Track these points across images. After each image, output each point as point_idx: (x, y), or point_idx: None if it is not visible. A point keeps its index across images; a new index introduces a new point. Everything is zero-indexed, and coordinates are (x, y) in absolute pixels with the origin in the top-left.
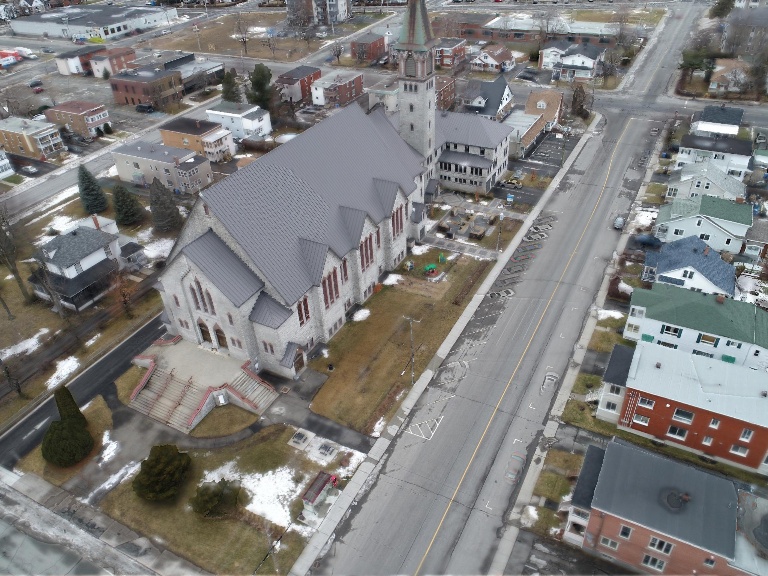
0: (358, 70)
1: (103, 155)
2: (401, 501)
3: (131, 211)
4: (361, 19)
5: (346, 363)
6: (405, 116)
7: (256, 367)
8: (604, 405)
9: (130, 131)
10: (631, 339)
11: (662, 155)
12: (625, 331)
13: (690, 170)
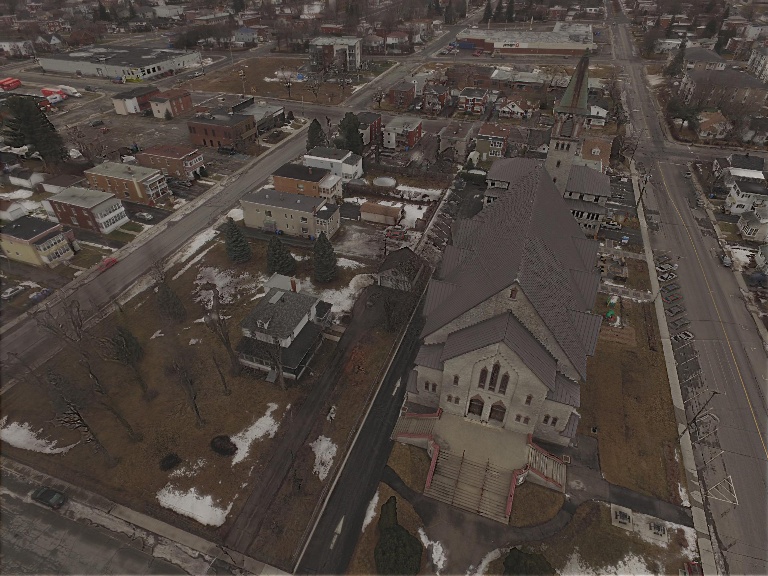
0: (400, 114)
1: (210, 199)
2: None
3: (286, 262)
4: (375, 67)
5: (603, 423)
6: (550, 171)
7: None
8: None
9: (223, 174)
10: None
11: (709, 196)
12: None
13: (767, 214)
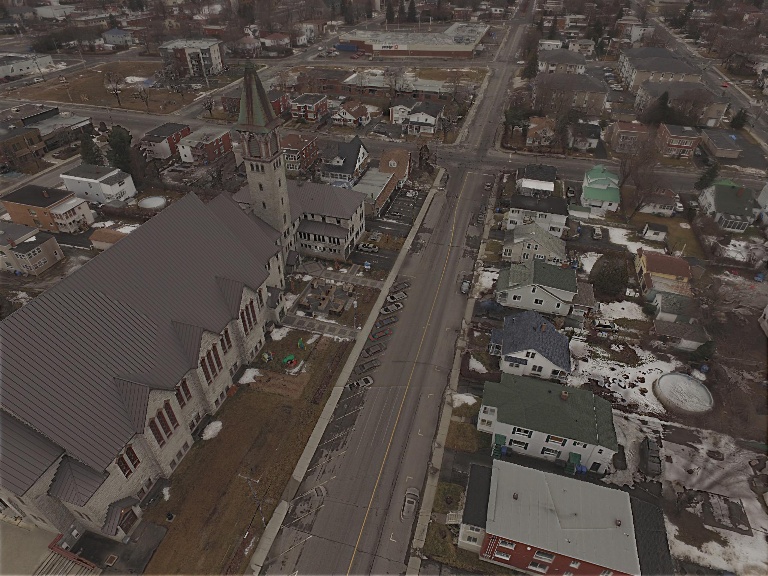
0: (230, 123)
1: None
2: None
3: None
4: (235, 71)
5: (189, 506)
6: (256, 194)
7: (74, 534)
8: (465, 538)
9: None
10: (485, 431)
11: (496, 210)
12: (479, 425)
13: (521, 232)
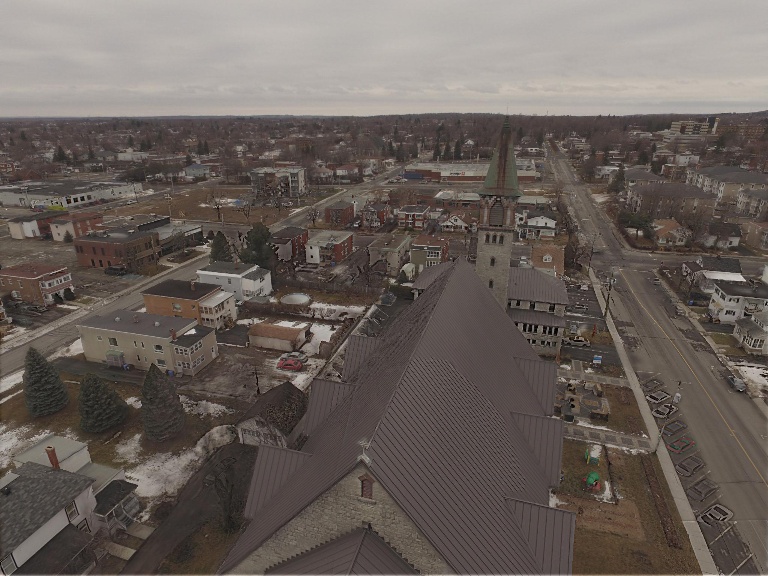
0: None
1: (61, 327)
2: None
3: (107, 412)
4: (319, 193)
5: None
6: (483, 271)
7: None
8: None
9: (98, 296)
10: None
11: (688, 303)
12: None
13: None
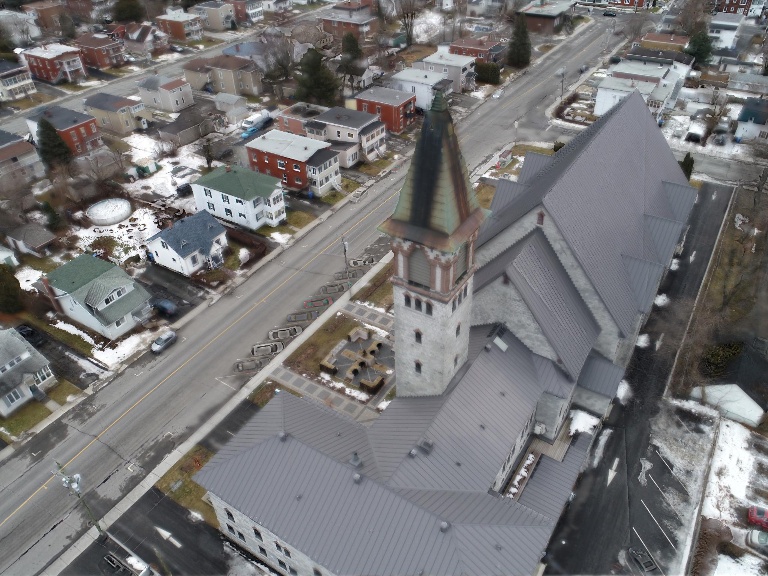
0: None
1: None
2: None
3: None
4: None
5: None
6: None
7: None
8: None
9: None
10: None
11: None
12: None
13: (3, 354)
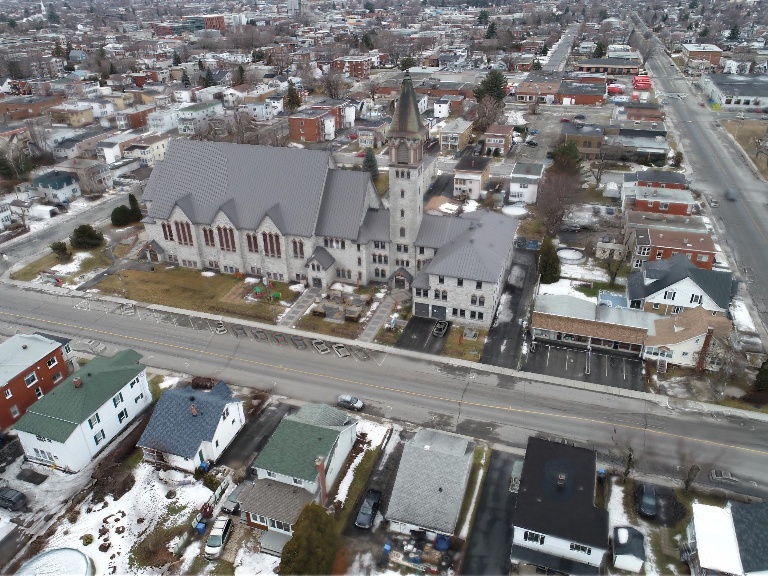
0: None
1: None
2: (34, 302)
3: None
4: None
5: (156, 274)
6: None
7: None
8: None
9: (506, 161)
10: None
11: None
12: None
13: (437, 438)
